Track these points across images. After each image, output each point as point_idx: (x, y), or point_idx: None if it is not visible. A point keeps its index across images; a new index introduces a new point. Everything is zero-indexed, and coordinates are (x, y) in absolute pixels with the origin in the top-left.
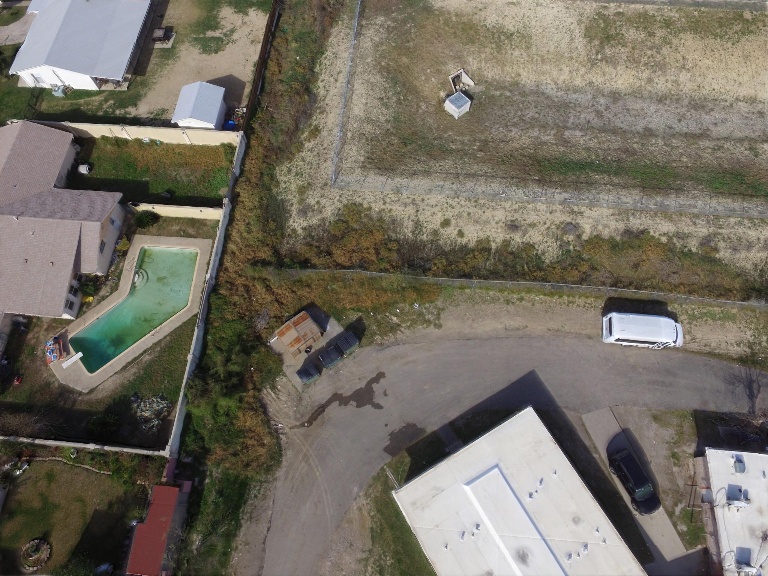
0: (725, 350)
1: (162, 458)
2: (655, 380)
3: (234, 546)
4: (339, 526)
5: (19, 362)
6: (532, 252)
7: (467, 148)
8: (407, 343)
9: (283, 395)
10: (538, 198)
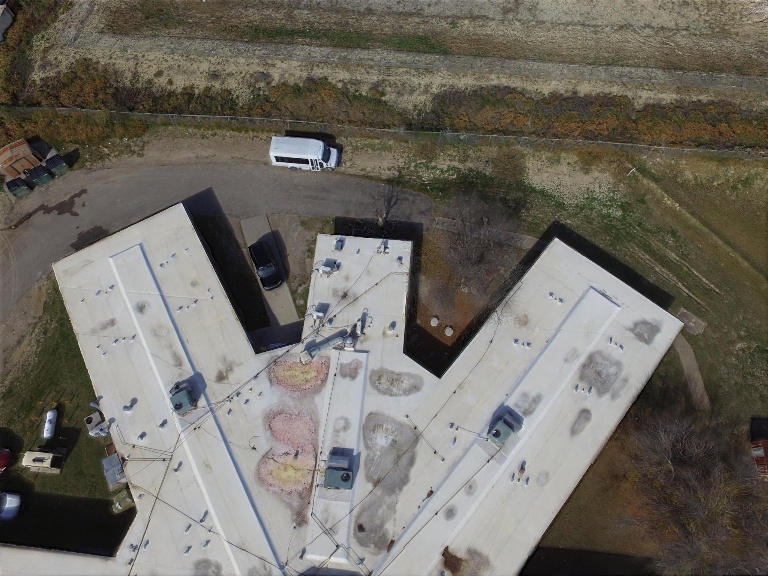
0: (377, 173)
1: None
2: (310, 195)
3: None
4: (19, 299)
5: None
6: (228, 96)
7: (202, 21)
8: (111, 168)
9: None
10: (240, 54)
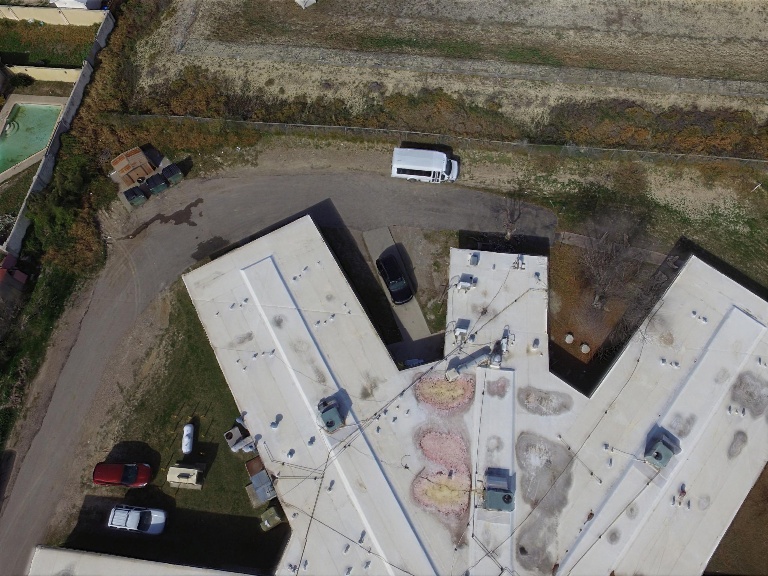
0: (497, 186)
1: (3, 255)
2: (431, 207)
3: (56, 325)
4: (144, 311)
5: None
6: (341, 106)
7: (305, 29)
8: (226, 177)
9: (115, 215)
10: (352, 63)
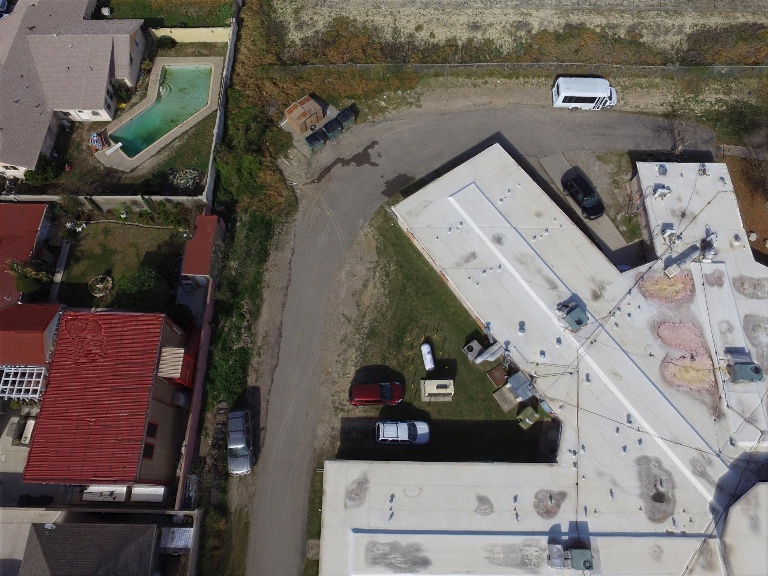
0: (651, 109)
1: (199, 206)
2: (597, 132)
3: (265, 268)
4: (350, 247)
5: (67, 155)
6: (492, 46)
7: None
8: (394, 119)
9: (295, 162)
10: (494, 5)
